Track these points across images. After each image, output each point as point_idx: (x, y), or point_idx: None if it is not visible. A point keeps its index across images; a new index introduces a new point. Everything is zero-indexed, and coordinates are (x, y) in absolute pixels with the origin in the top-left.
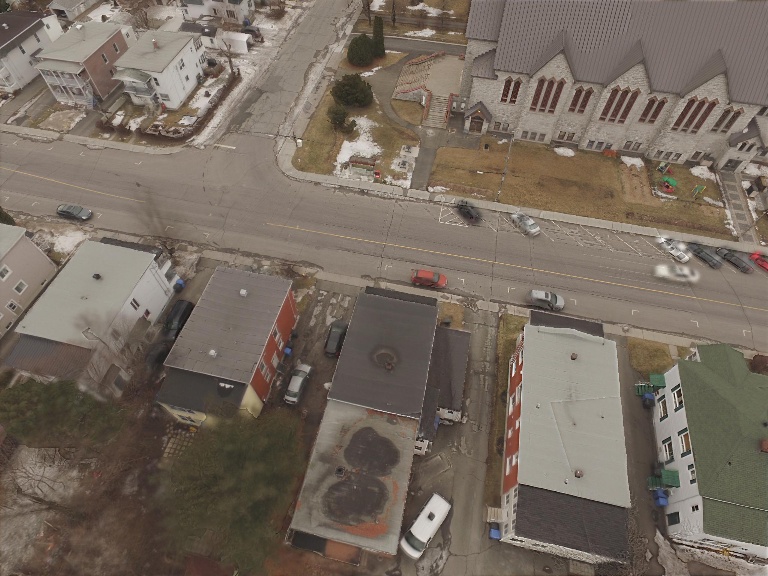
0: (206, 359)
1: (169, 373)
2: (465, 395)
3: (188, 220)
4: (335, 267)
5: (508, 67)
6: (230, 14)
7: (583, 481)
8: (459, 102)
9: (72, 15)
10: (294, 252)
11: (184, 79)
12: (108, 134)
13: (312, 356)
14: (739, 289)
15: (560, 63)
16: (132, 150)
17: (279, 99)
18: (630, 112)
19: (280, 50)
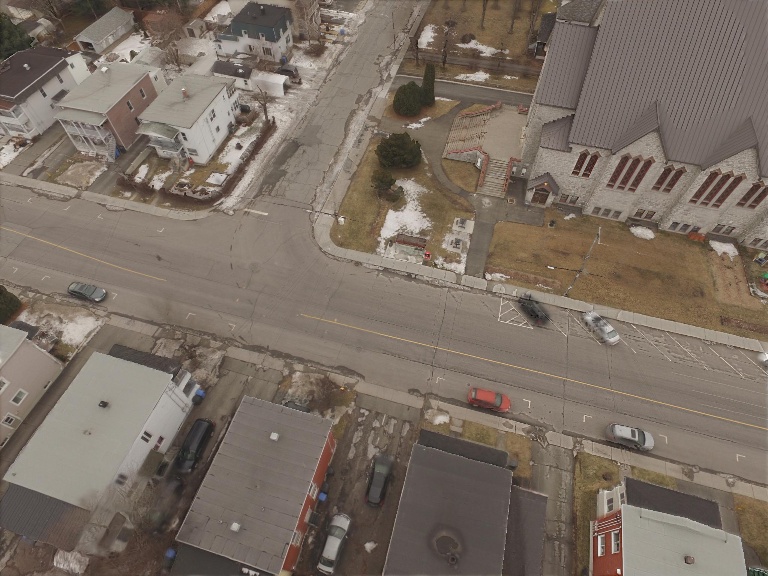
0: (227, 534)
1: (182, 549)
2: None
3: (212, 306)
4: (378, 376)
5: (586, 141)
6: (266, 51)
7: None
8: (520, 167)
9: (100, 48)
10: (331, 354)
11: (214, 130)
12: (129, 193)
13: (351, 502)
14: None
15: (651, 141)
16: (154, 213)
17: (317, 154)
18: (729, 197)
19: (319, 94)
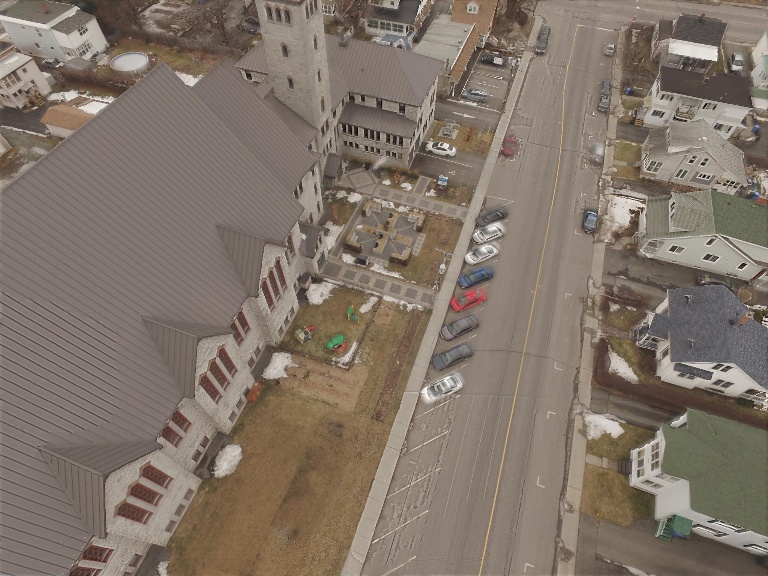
0: None
1: None
2: None
3: None
4: None
5: None
6: None
7: None
8: None
9: None
10: None
11: None
12: None
13: None
14: (501, 344)
15: (117, 476)
16: None
17: None
18: (233, 361)
19: None
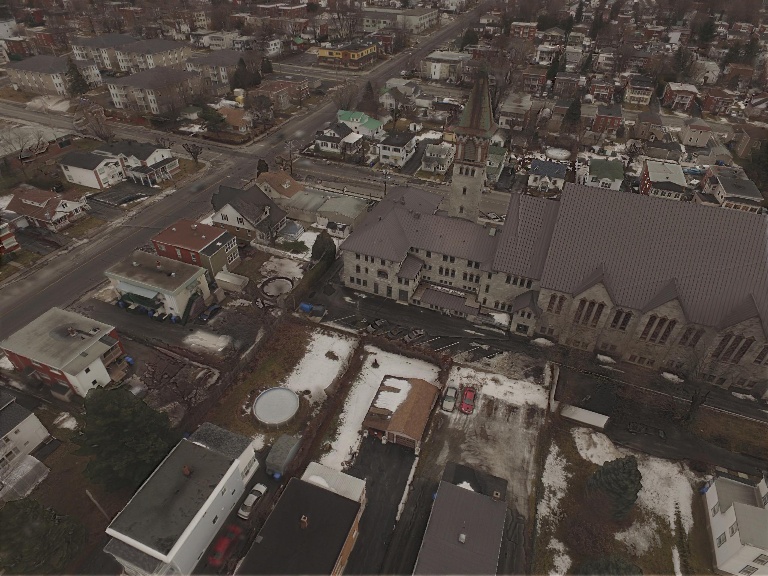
0: None
1: None
2: None
3: None
4: None
5: None
6: None
7: (661, 163)
8: None
9: None
10: None
11: None
12: None
13: None
14: None
15: None
16: None
17: None
18: None
19: None
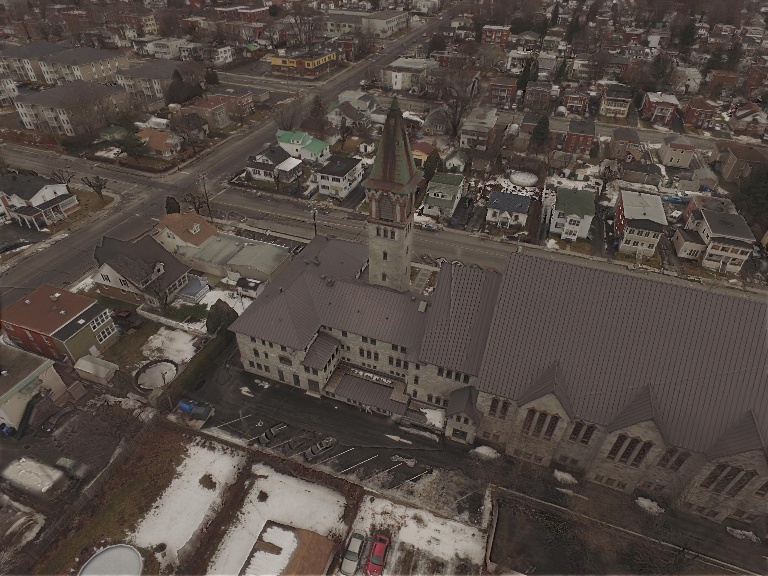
0: None
1: None
2: (672, 244)
3: None
4: None
5: None
6: None
7: (638, 194)
8: None
9: None
10: None
11: None
12: None
13: None
14: None
15: None
16: None
17: None
18: None
19: None
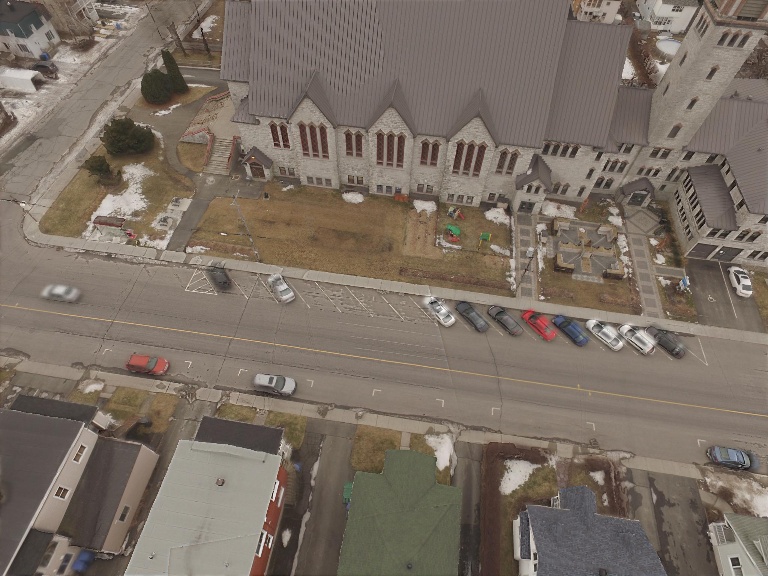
0: None
1: None
2: (140, 517)
3: None
4: (44, 354)
5: (264, 112)
6: (23, 48)
7: None
8: None
9: None
10: (1, 337)
11: None
12: None
13: None
14: (500, 356)
15: (312, 108)
16: None
17: (52, 146)
18: (404, 156)
19: (75, 87)
